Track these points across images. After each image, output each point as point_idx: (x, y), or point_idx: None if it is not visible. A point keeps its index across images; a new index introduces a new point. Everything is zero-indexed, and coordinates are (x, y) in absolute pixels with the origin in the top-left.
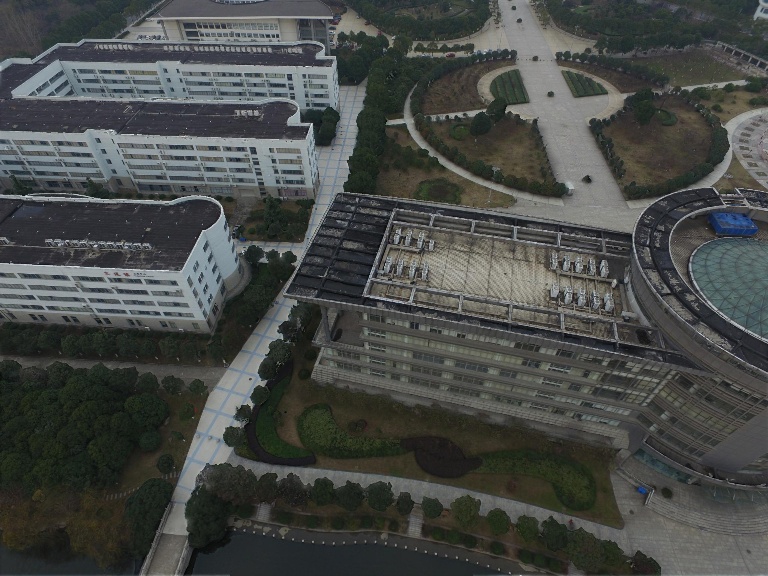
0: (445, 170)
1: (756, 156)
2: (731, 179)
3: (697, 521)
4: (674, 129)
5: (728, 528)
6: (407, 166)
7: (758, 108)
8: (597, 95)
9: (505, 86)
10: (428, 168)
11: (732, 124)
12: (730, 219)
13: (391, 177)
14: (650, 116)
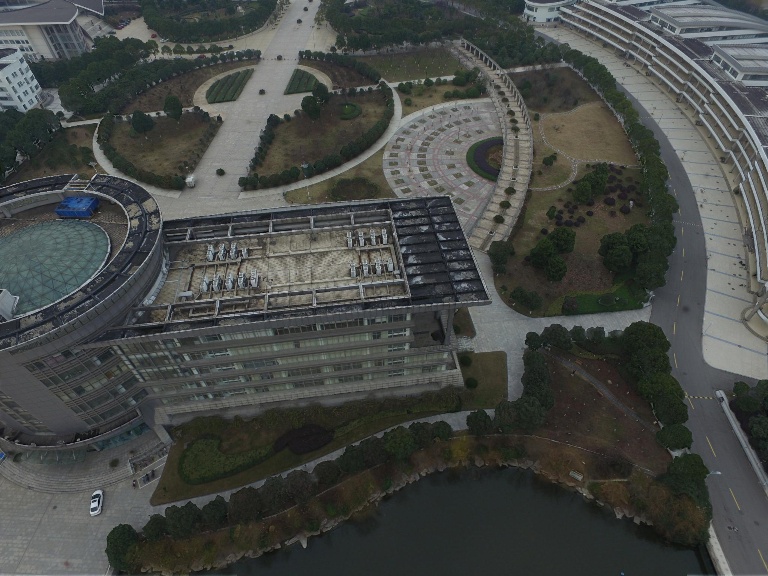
0: (95, 167)
1: (404, 147)
2: (360, 169)
3: (29, 482)
4: (350, 123)
5: (52, 487)
6: (61, 164)
7: (449, 101)
8: (307, 92)
9: (224, 85)
10: (75, 165)
11: (410, 117)
12: (73, 202)
13: (37, 174)
14: (313, 111)
